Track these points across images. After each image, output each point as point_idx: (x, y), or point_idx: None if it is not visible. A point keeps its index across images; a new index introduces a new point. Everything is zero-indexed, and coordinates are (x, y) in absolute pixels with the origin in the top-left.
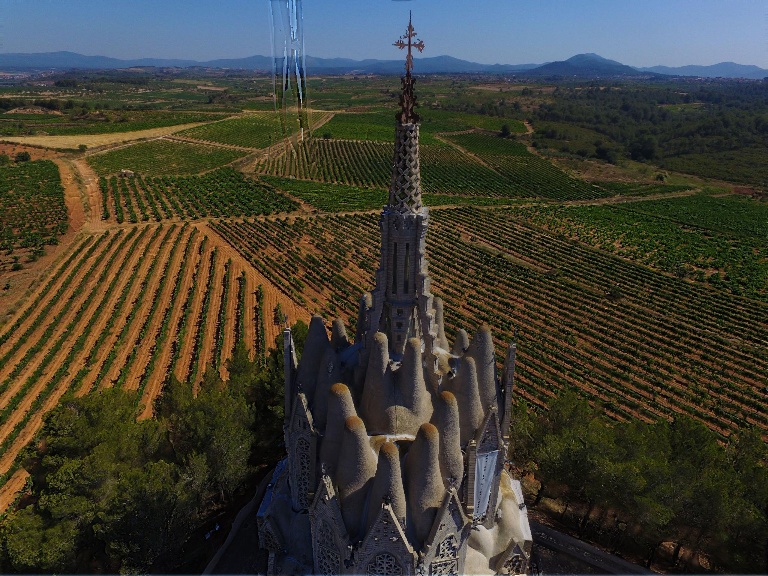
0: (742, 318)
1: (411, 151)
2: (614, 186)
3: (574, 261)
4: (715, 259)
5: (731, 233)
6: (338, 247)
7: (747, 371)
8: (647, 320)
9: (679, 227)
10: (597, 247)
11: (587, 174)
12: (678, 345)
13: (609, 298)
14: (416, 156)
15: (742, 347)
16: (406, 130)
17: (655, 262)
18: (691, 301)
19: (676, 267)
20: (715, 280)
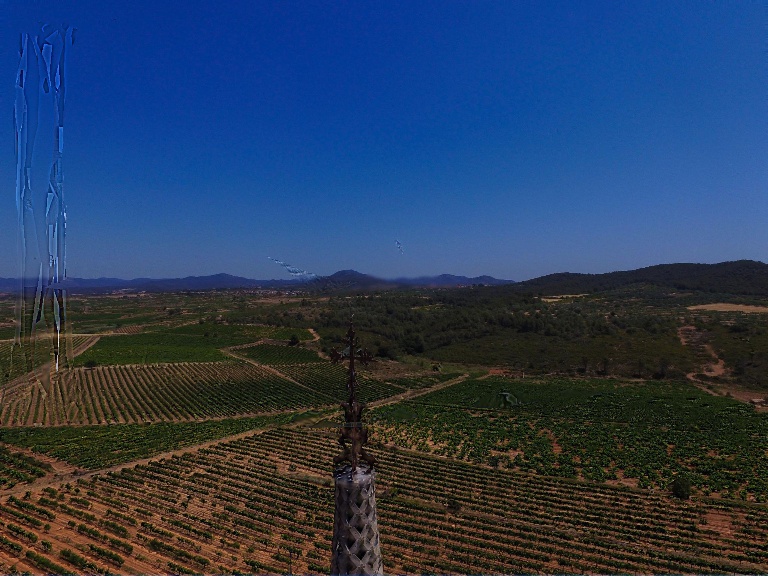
0: (561, 501)
1: (370, 520)
2: (403, 381)
3: (401, 472)
4: (509, 440)
5: (508, 411)
6: (114, 525)
7: (599, 566)
8: (495, 530)
9: (469, 413)
10: (414, 449)
11: (379, 373)
12: (535, 554)
13: (451, 511)
14: (375, 524)
15: (581, 537)
16: (360, 488)
17: (467, 455)
18: (516, 493)
19: (486, 456)
20: (520, 462)
